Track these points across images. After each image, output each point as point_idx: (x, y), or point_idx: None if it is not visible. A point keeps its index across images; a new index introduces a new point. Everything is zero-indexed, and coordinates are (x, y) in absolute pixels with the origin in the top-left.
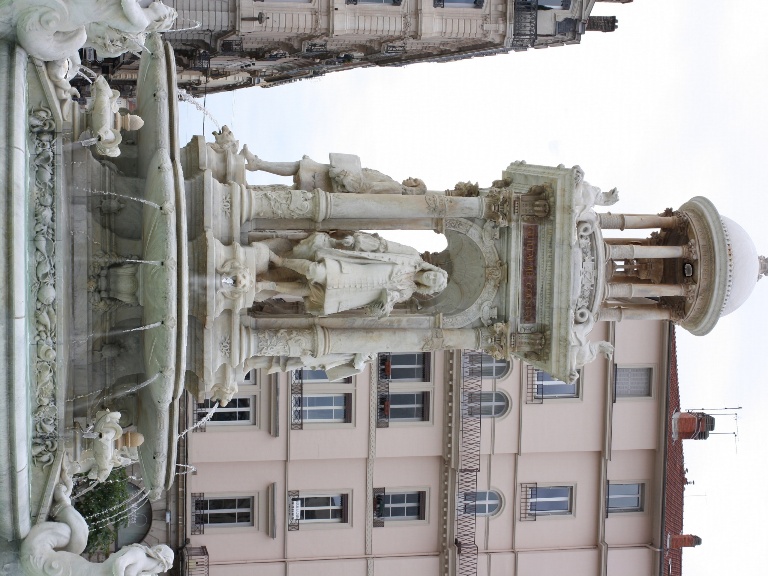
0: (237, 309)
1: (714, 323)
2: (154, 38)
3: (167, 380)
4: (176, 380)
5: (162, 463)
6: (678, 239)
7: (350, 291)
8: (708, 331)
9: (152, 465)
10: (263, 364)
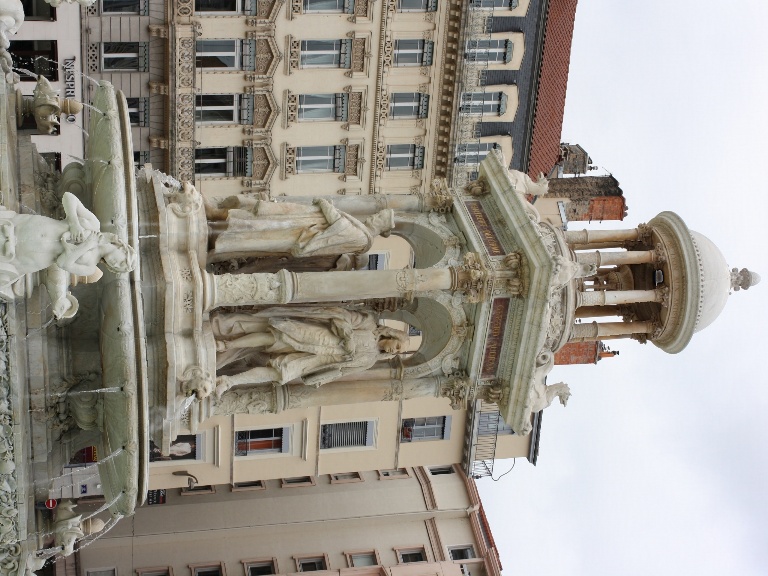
0: None
1: None
2: (127, 503)
3: None
4: None
5: None
6: None
7: None
8: None
9: None
10: None
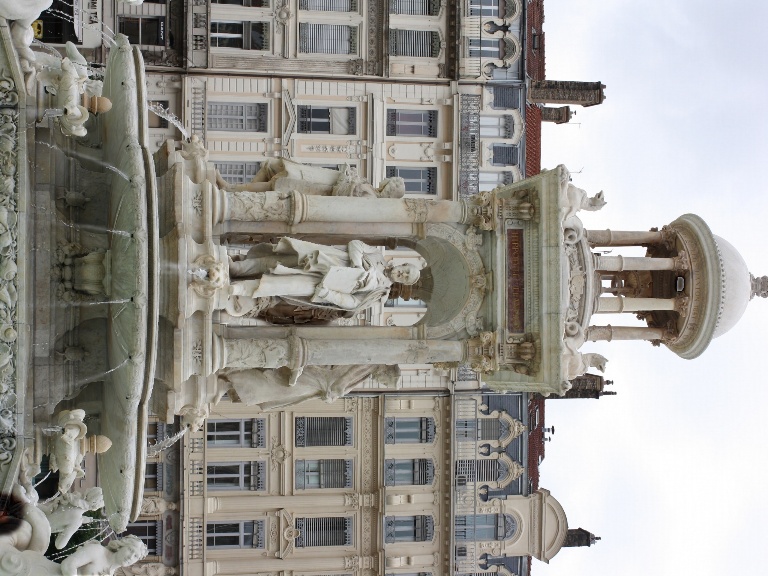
0: (198, 161)
1: (710, 234)
2: None
3: (126, 54)
4: (137, 76)
5: (137, 150)
6: (668, 319)
7: (307, 166)
8: (715, 248)
9: (127, 159)
10: (253, 281)
